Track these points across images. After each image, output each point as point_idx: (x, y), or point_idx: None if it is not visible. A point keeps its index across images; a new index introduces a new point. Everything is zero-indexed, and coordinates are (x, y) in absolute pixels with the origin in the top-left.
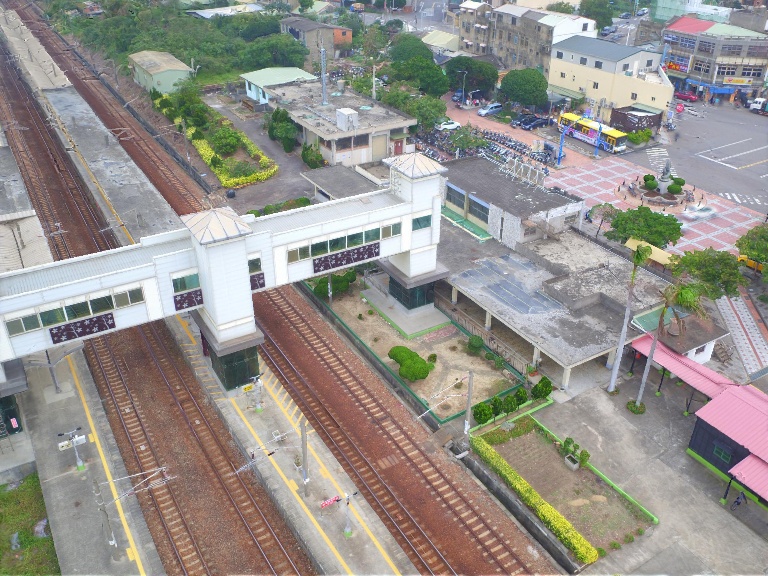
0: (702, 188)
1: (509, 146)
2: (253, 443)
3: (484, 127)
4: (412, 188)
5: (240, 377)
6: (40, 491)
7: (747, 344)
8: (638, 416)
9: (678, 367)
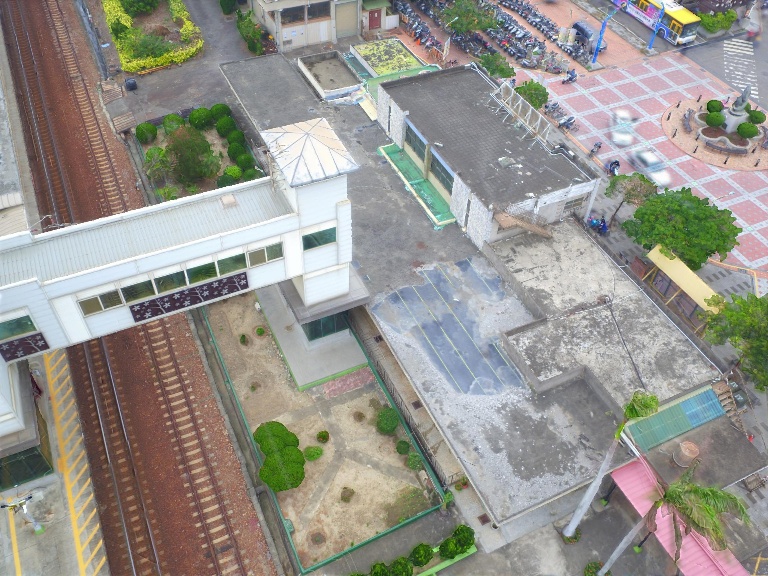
0: None
1: (532, 23)
2: None
3: None
4: (297, 195)
5: (18, 474)
6: None
7: None
8: None
9: None
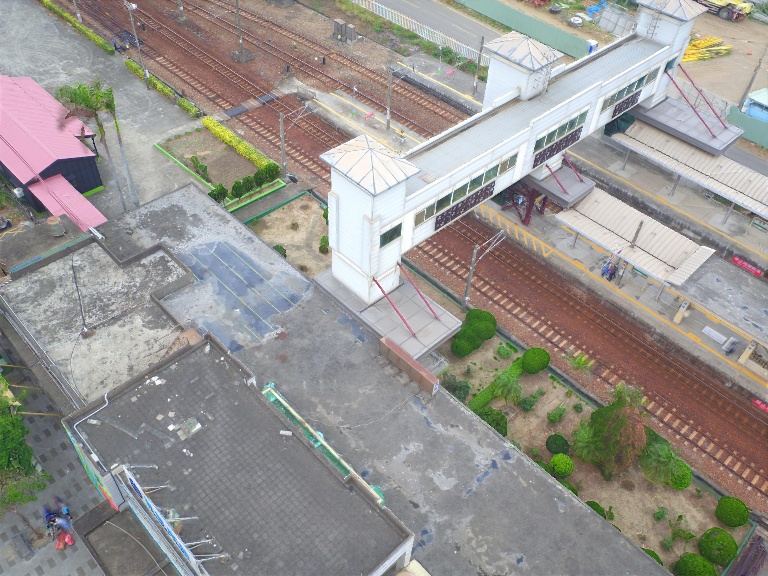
0: None
1: None
2: None
3: None
4: None
5: None
6: None
7: None
8: None
9: (78, 206)
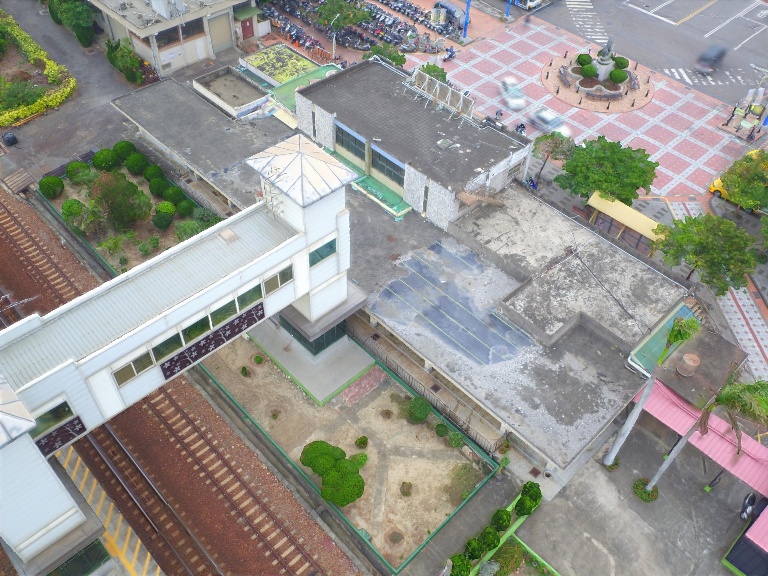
0: (643, 63)
1: (395, 8)
2: None
3: None
4: (304, 215)
5: (77, 571)
6: None
7: (751, 341)
8: (651, 505)
9: None
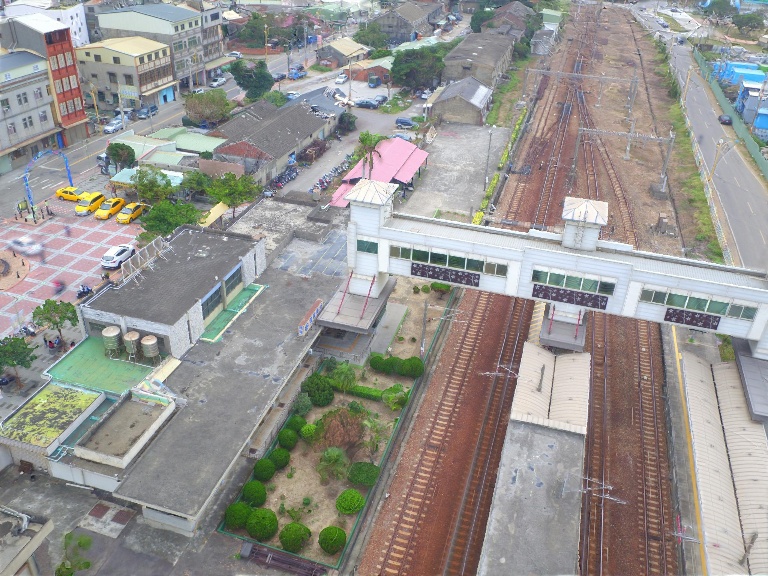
0: None
1: None
2: None
3: None
4: None
5: None
6: None
7: None
8: None
9: None
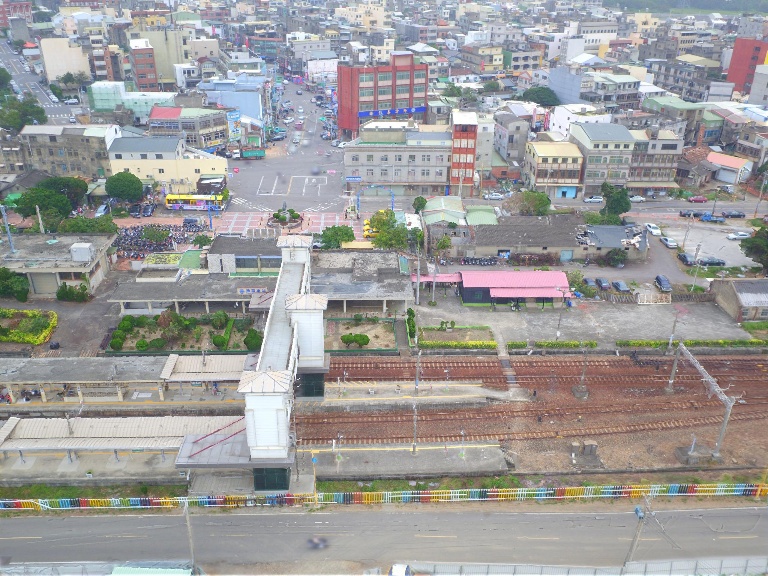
0: None
1: None
2: (368, 401)
3: (119, 225)
4: None
5: None
6: (334, 482)
7: None
8: (437, 306)
9: None
